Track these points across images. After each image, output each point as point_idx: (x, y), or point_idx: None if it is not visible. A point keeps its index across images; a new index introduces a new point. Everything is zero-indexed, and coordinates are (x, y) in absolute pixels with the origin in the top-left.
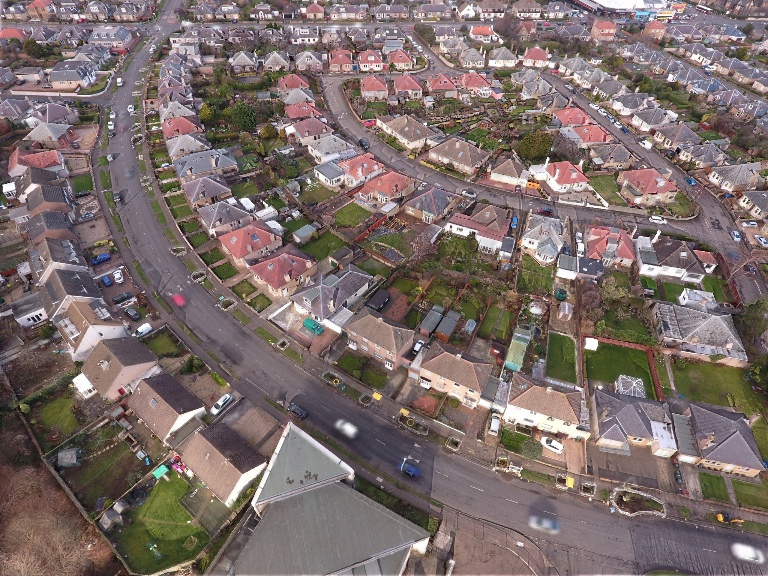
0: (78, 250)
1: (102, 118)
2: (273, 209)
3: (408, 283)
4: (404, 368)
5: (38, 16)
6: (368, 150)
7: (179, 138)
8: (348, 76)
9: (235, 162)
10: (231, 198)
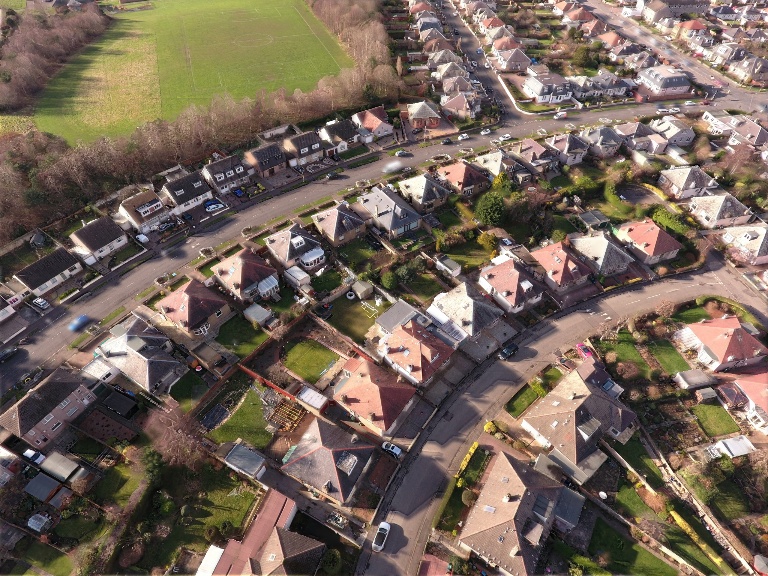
0: (238, 176)
1: (478, 129)
2: (302, 278)
3: (155, 440)
4: (15, 443)
5: (676, 35)
6: (496, 361)
7: (419, 176)
8: (762, 301)
9: (391, 227)
10: (301, 238)
